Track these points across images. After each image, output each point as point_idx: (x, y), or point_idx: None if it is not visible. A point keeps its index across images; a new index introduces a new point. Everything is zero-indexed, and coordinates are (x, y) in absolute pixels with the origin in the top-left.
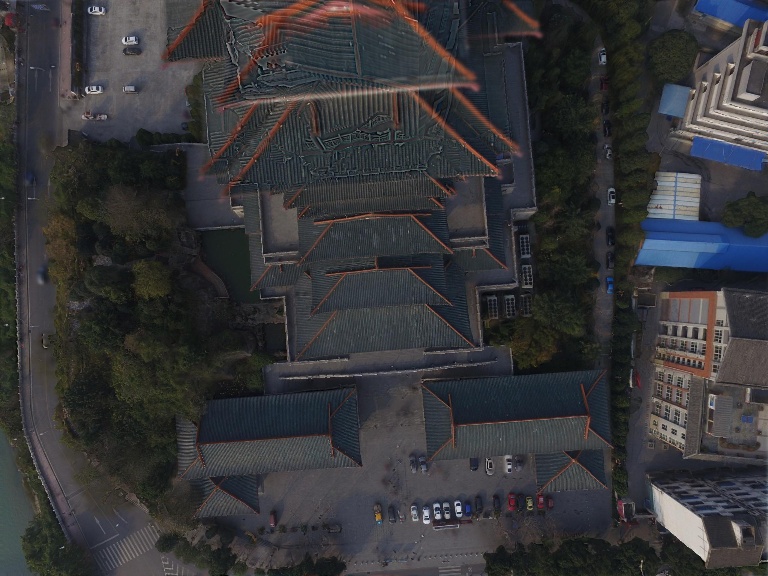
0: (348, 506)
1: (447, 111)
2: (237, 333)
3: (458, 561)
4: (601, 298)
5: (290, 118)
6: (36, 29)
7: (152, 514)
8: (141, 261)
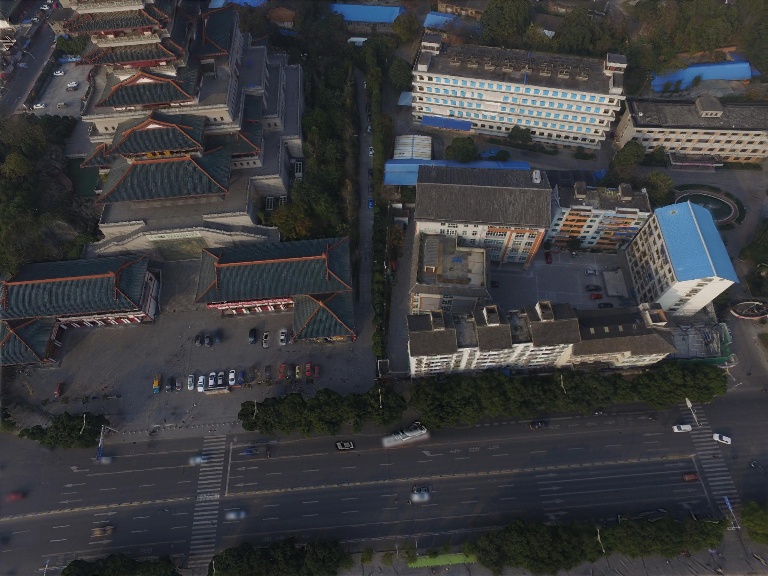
0: (132, 378)
1: None
2: (71, 216)
3: (225, 430)
4: (366, 213)
5: None
6: (18, 82)
7: None
8: None
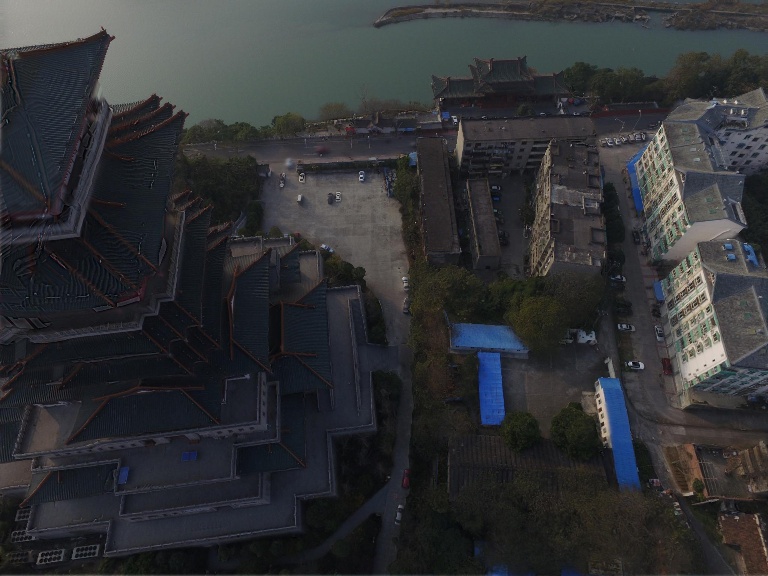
0: None
1: (2, 342)
2: None
3: None
4: None
5: None
6: (348, 145)
7: None
8: None
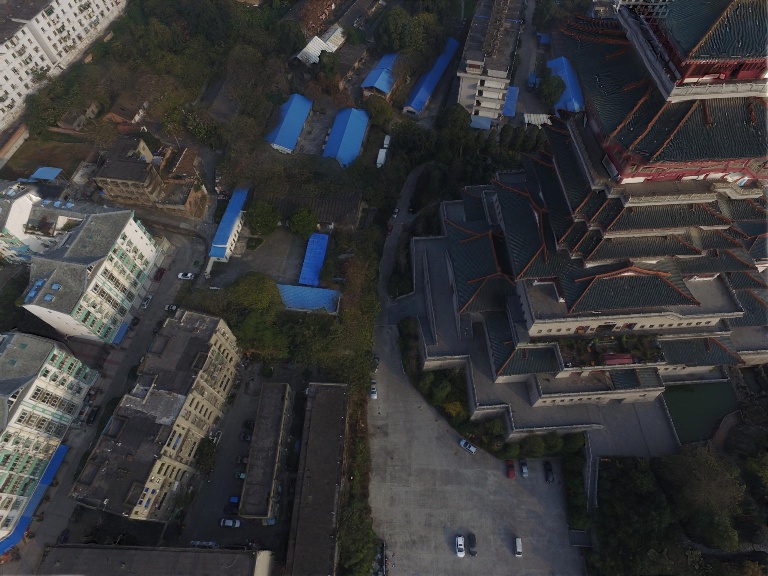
0: None
1: None
2: None
3: None
4: None
5: None
6: None
7: None
8: (760, 477)
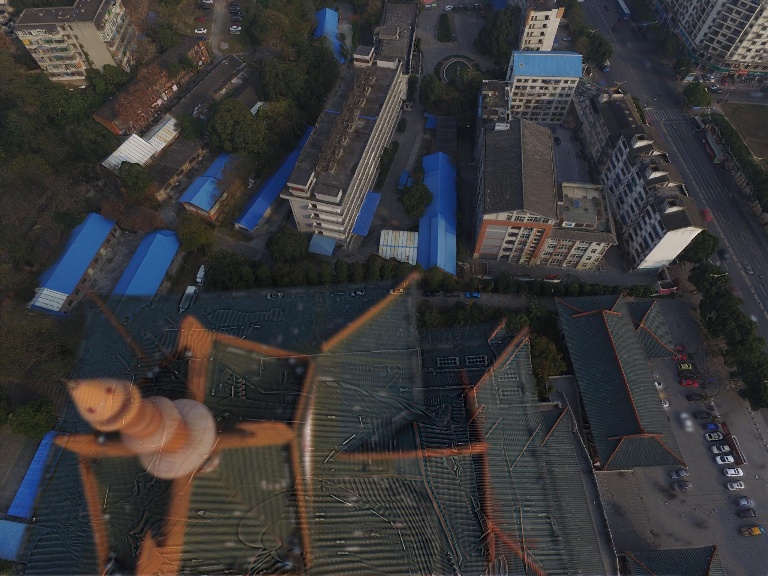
0: (756, 572)
1: None
2: None
3: None
4: (484, 302)
5: (463, 574)
6: None
7: None
8: None
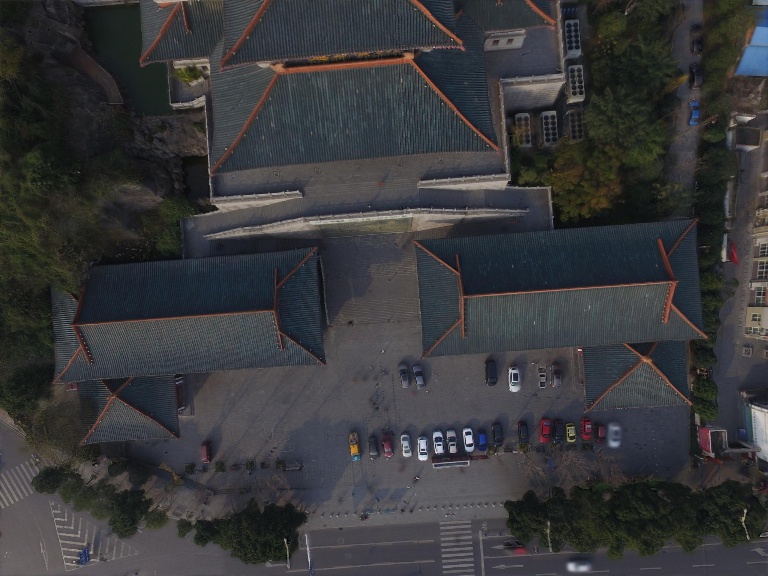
0: (312, 435)
1: None
2: (138, 162)
3: (467, 514)
4: None
5: None
6: None
7: (27, 438)
8: None
